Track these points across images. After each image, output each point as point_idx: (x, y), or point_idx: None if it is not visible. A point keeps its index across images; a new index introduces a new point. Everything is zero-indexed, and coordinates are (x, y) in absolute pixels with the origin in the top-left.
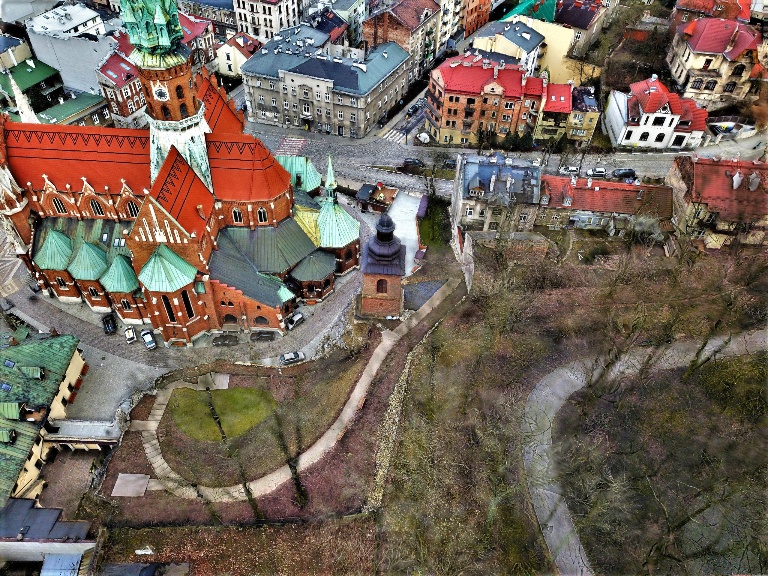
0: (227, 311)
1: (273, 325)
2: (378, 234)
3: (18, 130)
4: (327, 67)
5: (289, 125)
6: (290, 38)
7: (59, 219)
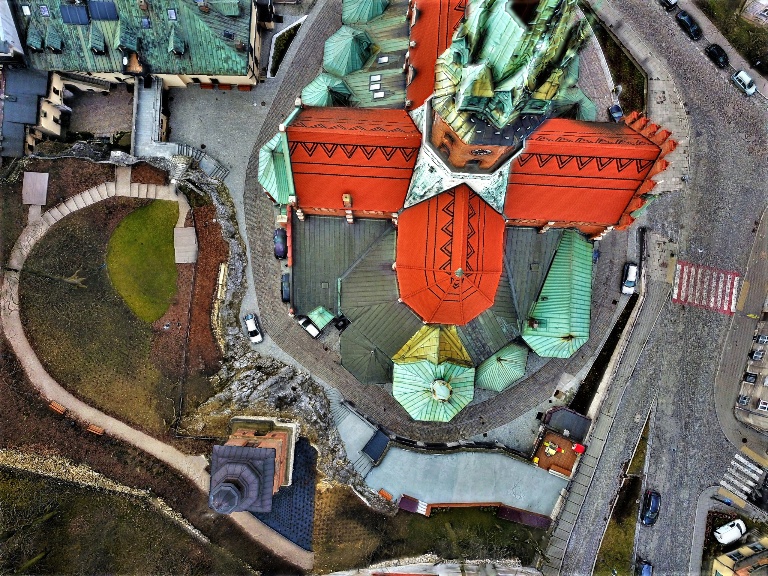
0: None
1: None
2: None
3: None
4: None
5: None
6: None
7: None
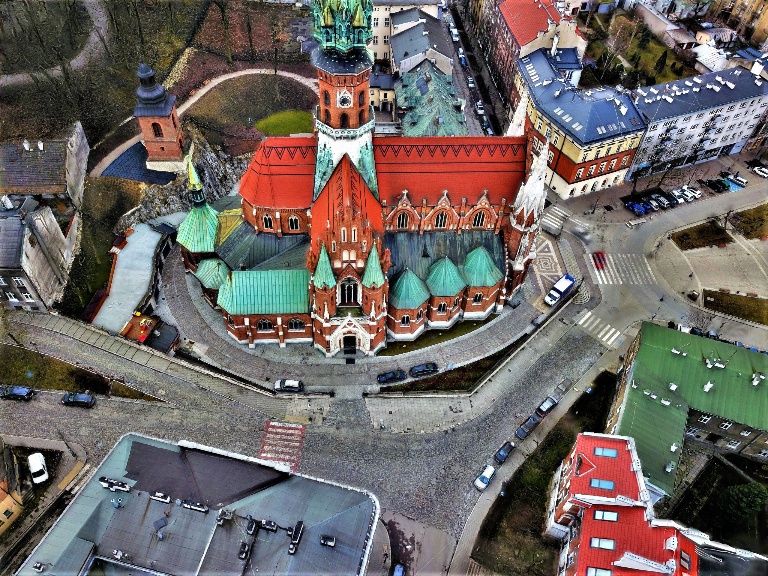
0: None
1: None
2: None
3: None
4: (187, 487)
5: None
6: None
7: None
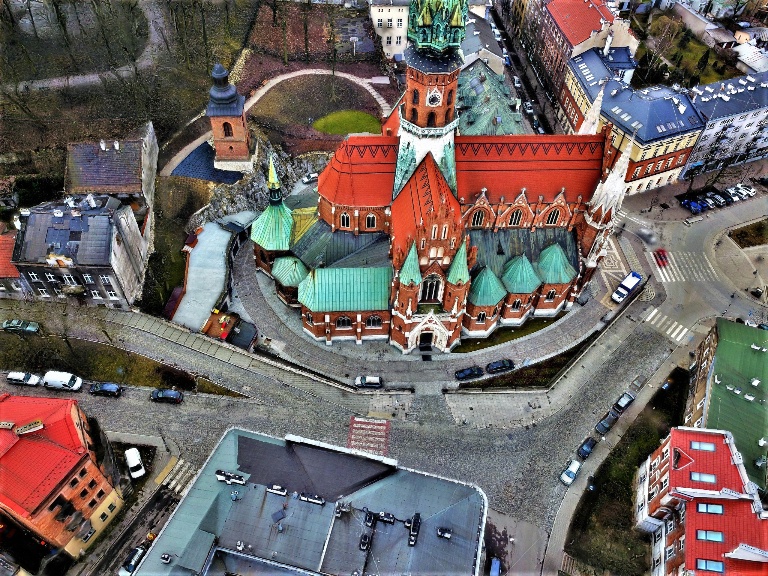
0: None
1: None
2: None
3: None
4: (300, 480)
5: None
6: None
7: None
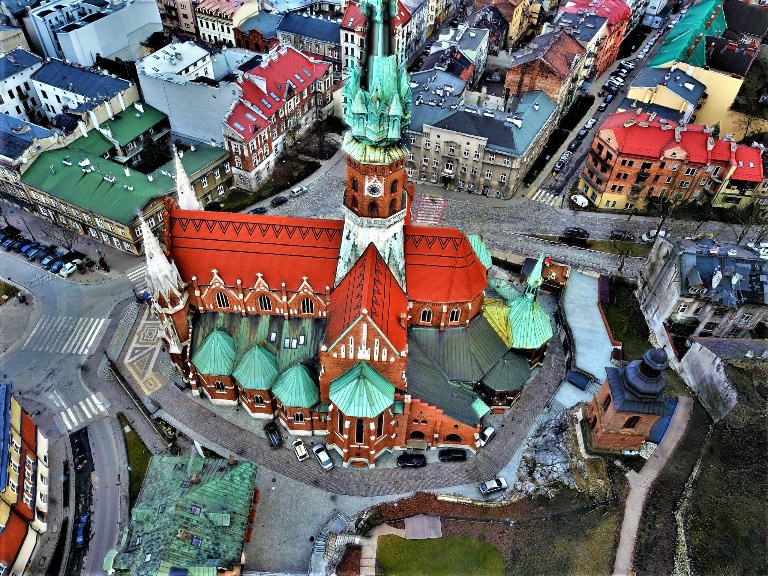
0: (417, 428)
1: (465, 442)
2: (645, 369)
3: (186, 218)
4: (477, 122)
5: (425, 182)
6: (428, 86)
7: (220, 314)
